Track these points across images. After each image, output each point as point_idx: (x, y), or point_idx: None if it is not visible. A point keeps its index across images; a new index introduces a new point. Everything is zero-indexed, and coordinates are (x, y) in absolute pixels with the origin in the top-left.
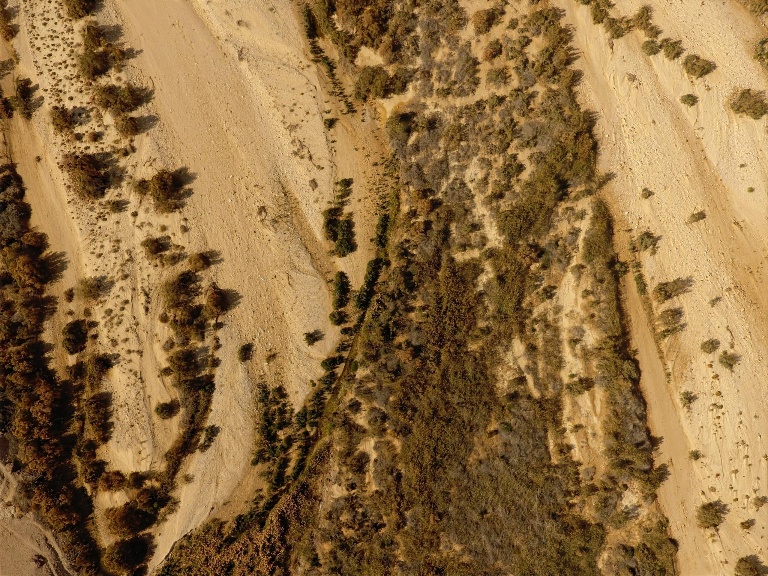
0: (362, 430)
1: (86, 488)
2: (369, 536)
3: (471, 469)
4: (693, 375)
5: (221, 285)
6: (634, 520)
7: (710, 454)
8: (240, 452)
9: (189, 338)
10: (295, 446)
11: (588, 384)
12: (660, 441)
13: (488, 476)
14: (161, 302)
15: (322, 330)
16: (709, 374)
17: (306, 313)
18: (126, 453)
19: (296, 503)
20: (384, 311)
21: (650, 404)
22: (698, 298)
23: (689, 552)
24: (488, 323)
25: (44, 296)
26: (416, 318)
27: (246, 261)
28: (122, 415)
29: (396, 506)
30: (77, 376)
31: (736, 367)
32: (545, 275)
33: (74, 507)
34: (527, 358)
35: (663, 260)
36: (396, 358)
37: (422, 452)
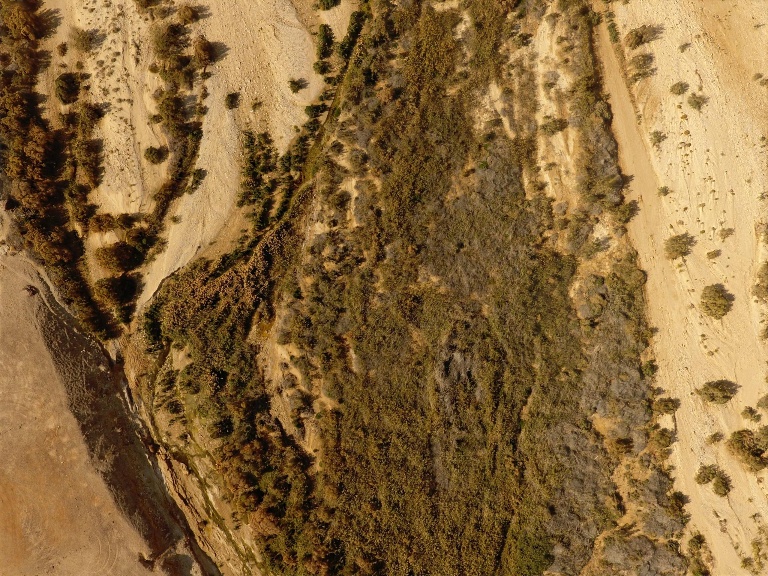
0: (344, 170)
1: (77, 231)
2: (350, 268)
3: (448, 205)
4: (663, 116)
5: (209, 38)
6: (605, 251)
7: (678, 189)
8: (226, 194)
9: (178, 87)
10: (279, 189)
11: (562, 125)
12: (631, 179)
13: (465, 210)
14: (151, 54)
15: (306, 79)
16: (678, 115)
17: (291, 63)
18: (116, 196)
19: (280, 239)
20: (366, 57)
21: (621, 145)
22: (668, 44)
23: (657, 282)
24: (466, 68)
25: (38, 50)
26: (397, 65)
27: (233, 15)
28: (113, 160)
29: (376, 237)
30: (69, 123)
31: (704, 108)
32: (521, 24)
33: (66, 246)
34: (503, 101)
35: (635, 9)
36: (377, 99)
37: (401, 188)
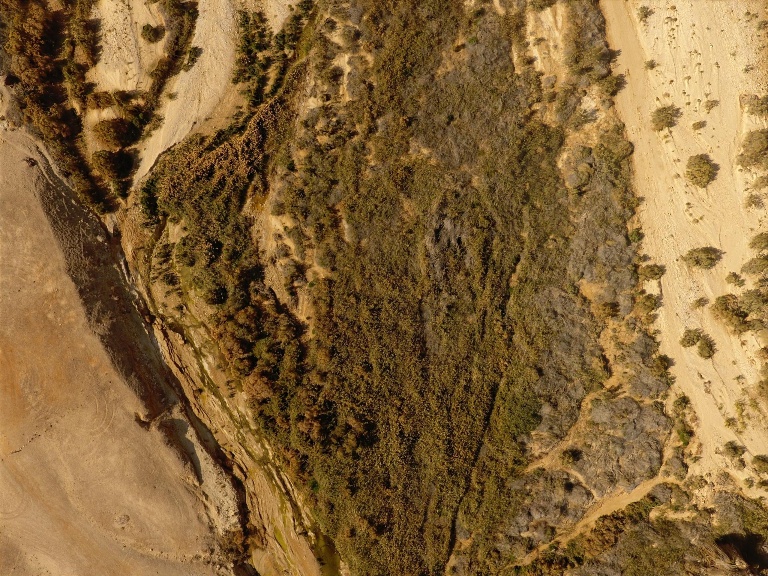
0: (337, 46)
1: (76, 108)
2: (342, 140)
3: (439, 79)
4: None
5: None
6: (592, 123)
7: (664, 63)
8: (221, 71)
9: None
10: (274, 67)
11: (550, 1)
12: (618, 54)
13: (455, 83)
14: None
15: None
16: None
17: None
18: (114, 73)
19: (274, 113)
20: None
21: (609, 21)
22: None
23: (644, 153)
24: None
25: None
26: None
27: None
28: (110, 39)
29: (368, 109)
30: (68, 4)
31: None
32: None
33: (64, 122)
34: None
35: None
36: None
37: (393, 62)
